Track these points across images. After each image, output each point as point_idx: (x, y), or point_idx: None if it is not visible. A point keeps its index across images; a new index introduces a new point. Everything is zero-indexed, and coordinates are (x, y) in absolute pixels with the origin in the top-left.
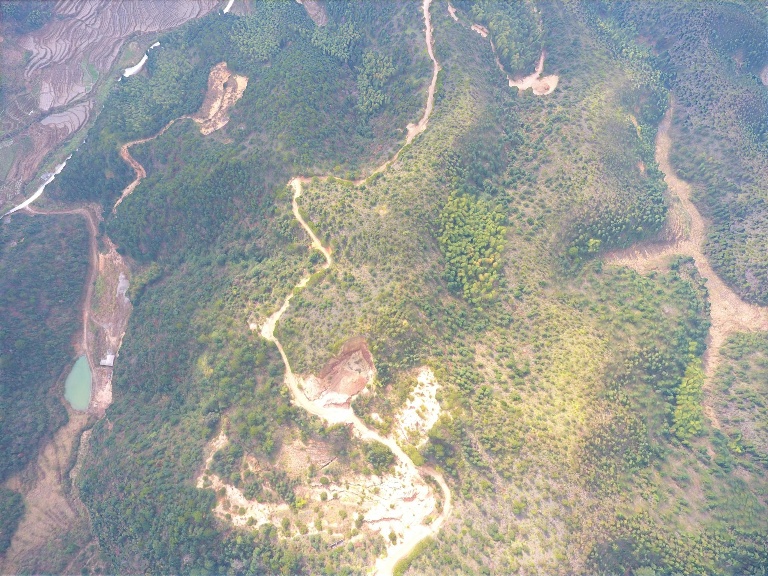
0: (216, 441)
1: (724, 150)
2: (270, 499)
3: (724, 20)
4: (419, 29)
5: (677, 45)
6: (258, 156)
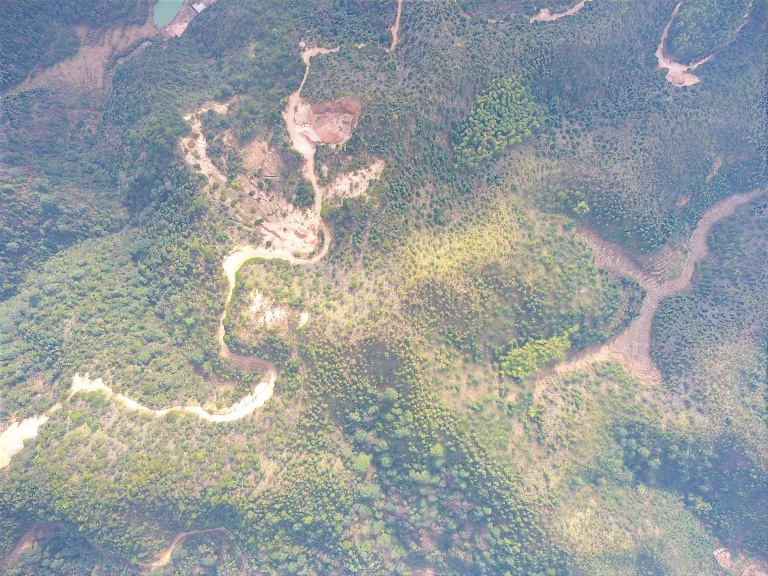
0: (219, 105)
1: (760, 248)
2: (220, 165)
3: None
4: None
5: None
6: None
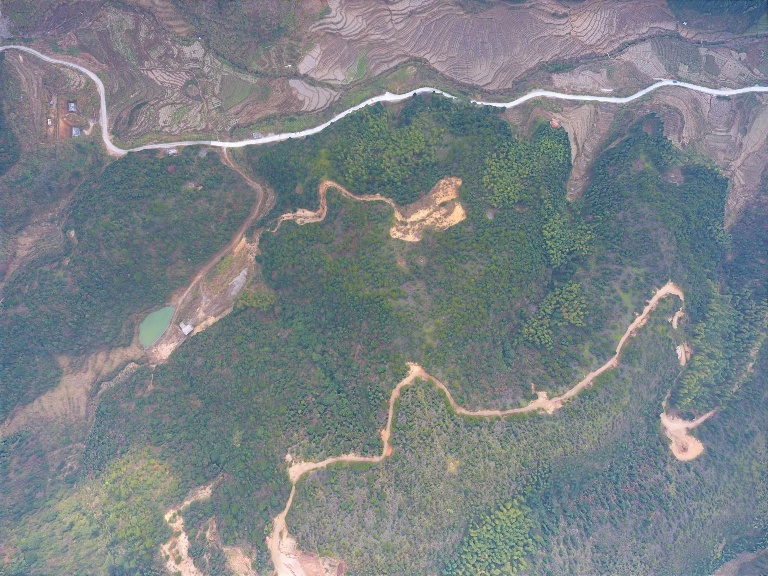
0: (202, 490)
1: None
2: (202, 570)
3: None
4: (635, 309)
5: None
6: (408, 320)
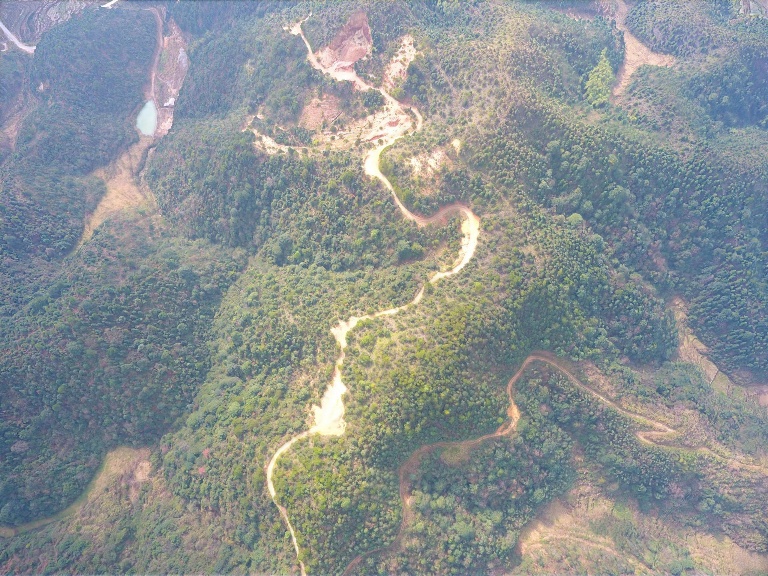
0: None
1: None
2: (294, 141)
3: None
4: None
5: None
6: None
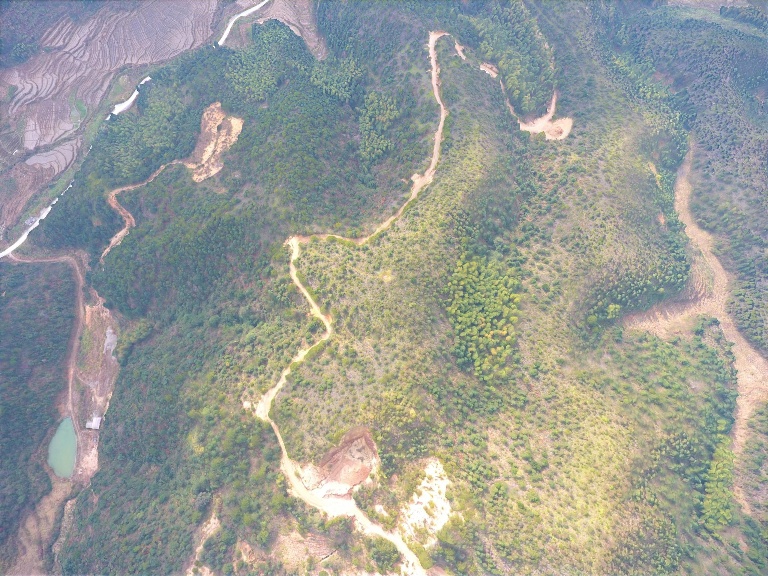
0: (207, 526)
1: (749, 200)
2: None
3: (746, 57)
4: (424, 69)
5: (696, 83)
6: (253, 212)
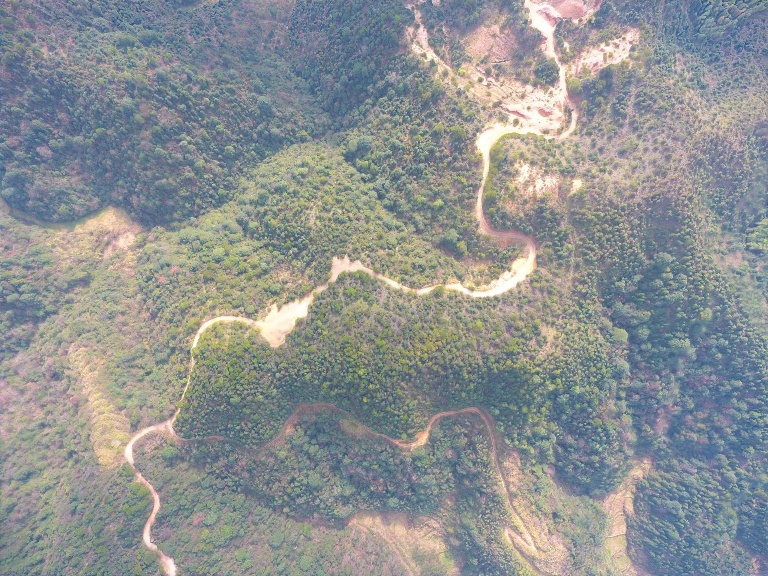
0: None
1: None
2: (444, 54)
3: None
4: None
5: None
6: None
